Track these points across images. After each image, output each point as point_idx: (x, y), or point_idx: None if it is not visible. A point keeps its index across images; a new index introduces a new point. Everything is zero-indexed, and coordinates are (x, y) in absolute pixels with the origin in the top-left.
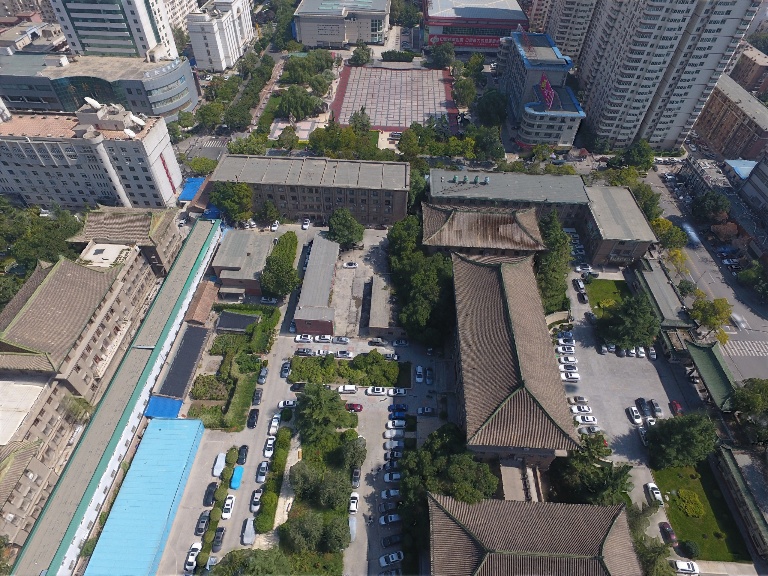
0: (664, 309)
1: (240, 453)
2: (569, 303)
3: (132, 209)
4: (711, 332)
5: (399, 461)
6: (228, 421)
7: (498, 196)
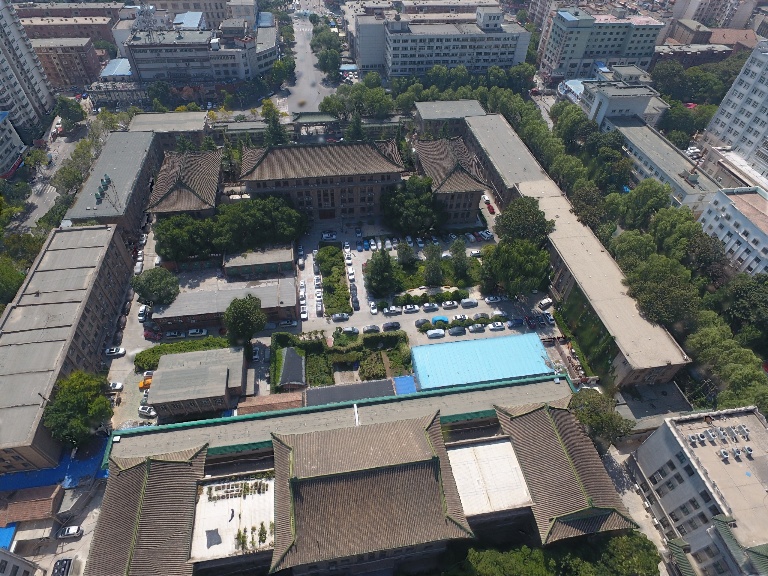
0: None
1: (424, 322)
2: None
3: (99, 539)
4: None
5: (411, 220)
6: (404, 333)
7: (133, 175)
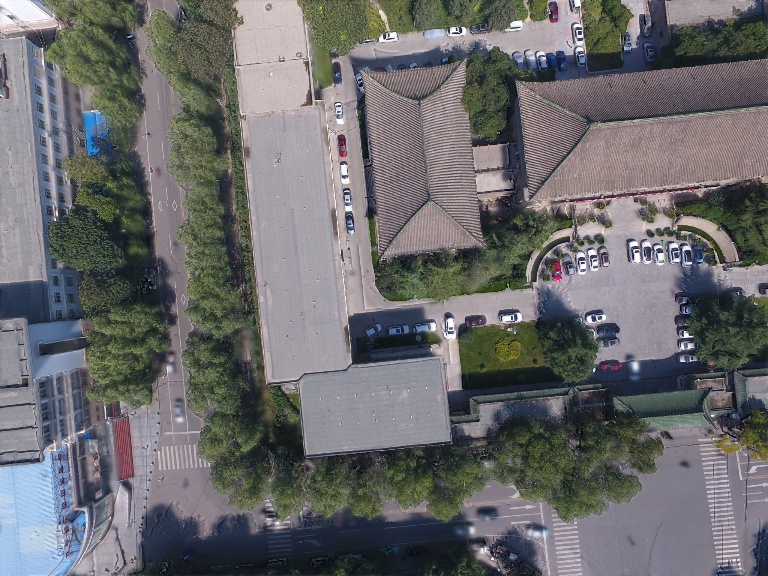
0: (764, 383)
1: None
2: (753, 258)
3: None
4: (735, 438)
5: (497, 47)
6: None
7: None
